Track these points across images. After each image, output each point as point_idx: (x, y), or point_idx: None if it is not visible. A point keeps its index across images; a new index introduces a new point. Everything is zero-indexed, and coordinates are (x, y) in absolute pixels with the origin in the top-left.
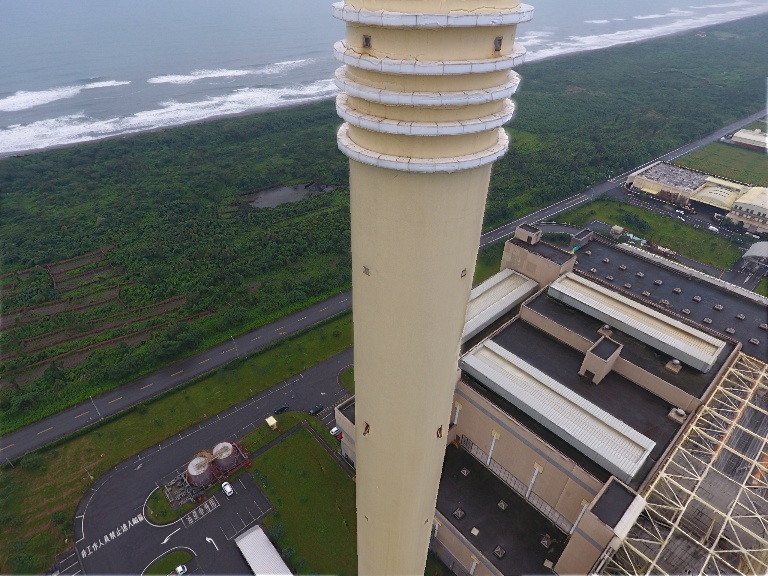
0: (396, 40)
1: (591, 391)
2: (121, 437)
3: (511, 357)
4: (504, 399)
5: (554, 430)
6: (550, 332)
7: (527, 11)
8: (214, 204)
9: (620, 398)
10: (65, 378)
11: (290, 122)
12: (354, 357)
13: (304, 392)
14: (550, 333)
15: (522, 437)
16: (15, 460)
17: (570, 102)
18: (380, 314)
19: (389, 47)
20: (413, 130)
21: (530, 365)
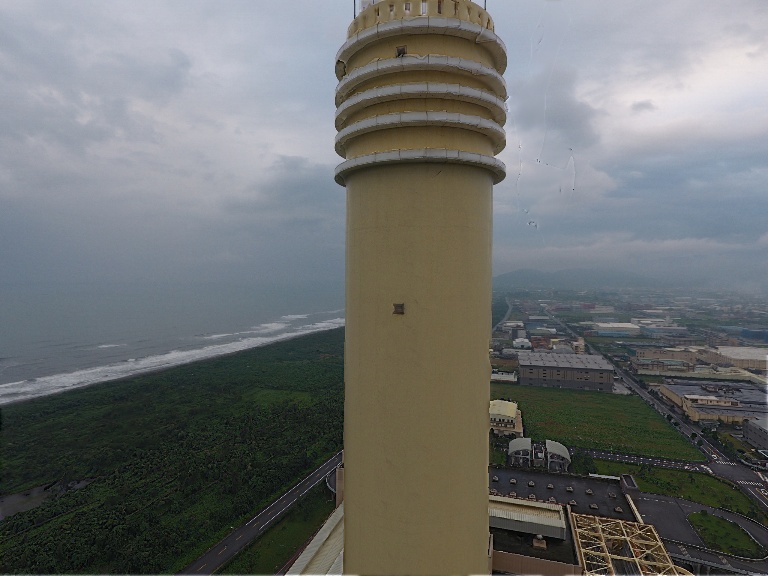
0: (434, 45)
1: None
2: None
3: None
4: None
5: None
6: None
7: None
8: None
9: None
10: None
11: (19, 417)
12: (359, 488)
13: None
14: None
15: None
16: None
17: (326, 365)
18: (421, 368)
19: (428, 51)
20: (461, 117)
21: None
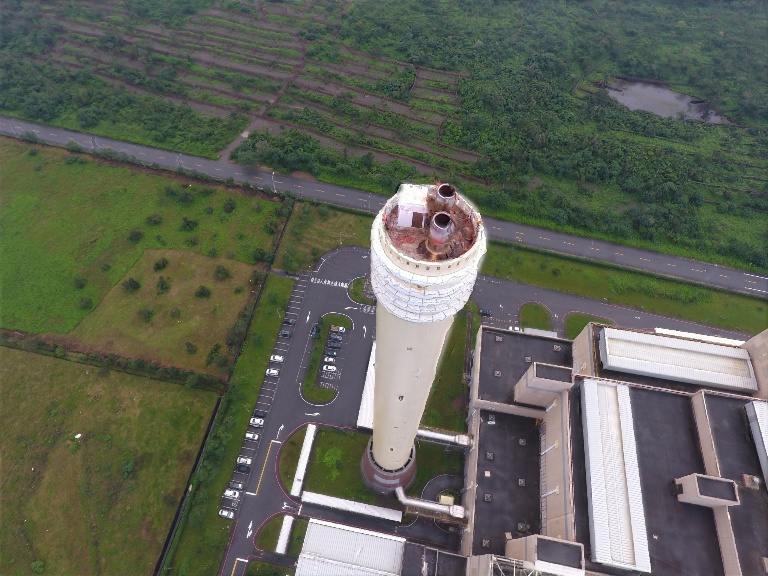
0: None
1: (665, 498)
2: (369, 231)
3: (626, 414)
4: (583, 432)
5: (588, 483)
6: (700, 432)
7: (437, 283)
8: (581, 74)
9: (683, 527)
10: (370, 168)
11: (763, 0)
12: None
13: (490, 294)
14: (699, 433)
15: (565, 463)
16: (318, 202)
17: None
18: None
19: None
20: None
21: (633, 433)
